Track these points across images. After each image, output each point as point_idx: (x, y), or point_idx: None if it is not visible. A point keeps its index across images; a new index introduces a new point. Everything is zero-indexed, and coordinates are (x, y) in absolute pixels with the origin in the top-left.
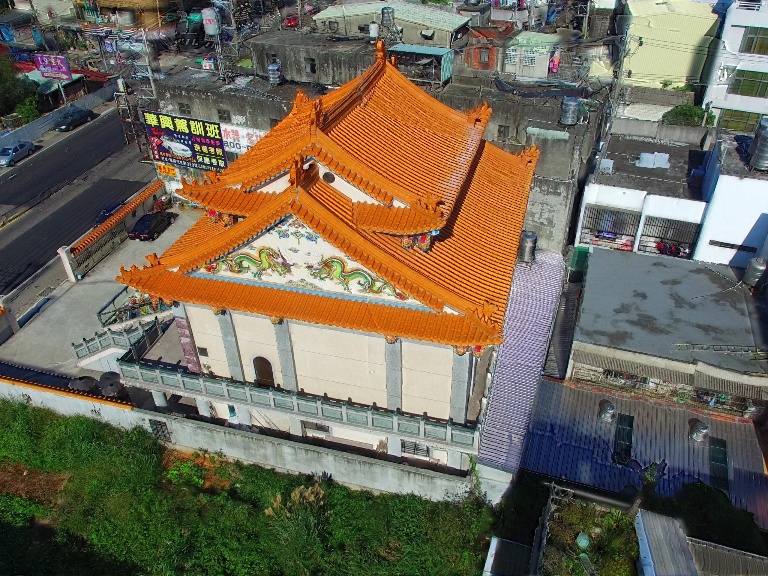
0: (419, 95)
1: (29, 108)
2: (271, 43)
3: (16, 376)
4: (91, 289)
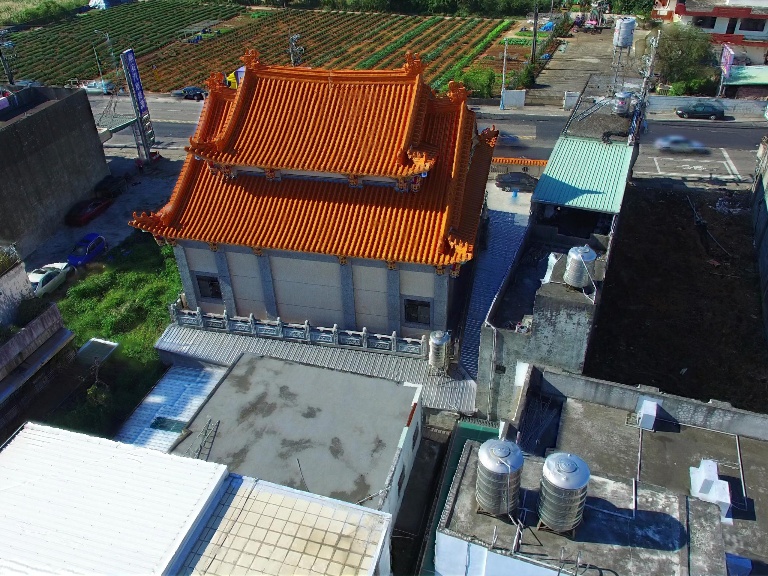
0: None
1: (679, 86)
2: None
3: None
4: None
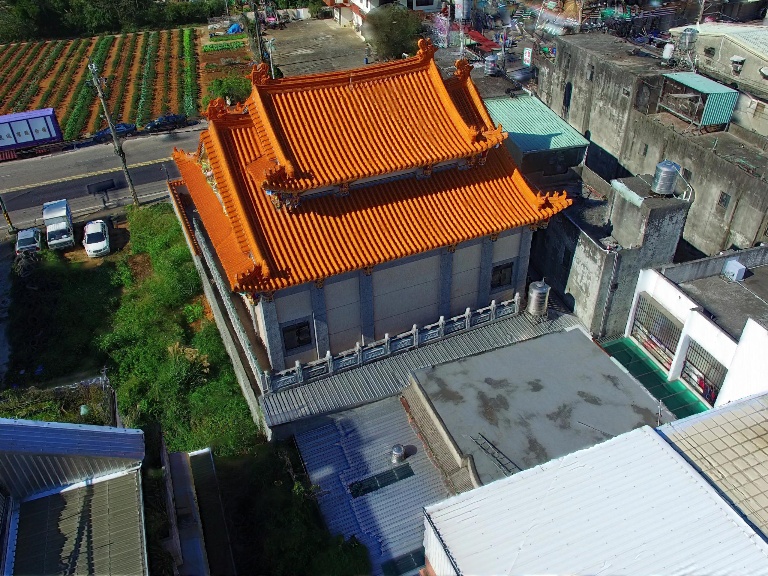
0: (445, 98)
1: None
2: (572, 43)
3: None
4: None
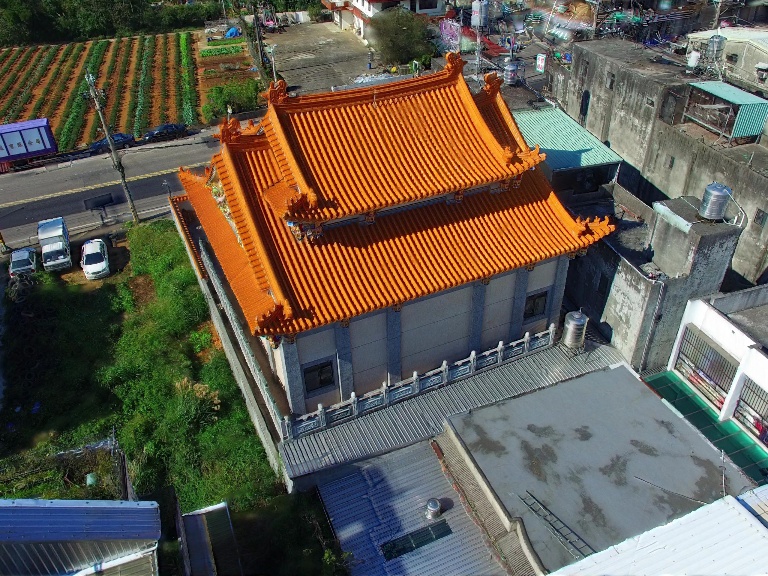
0: (475, 116)
1: None
2: (589, 49)
3: None
4: None
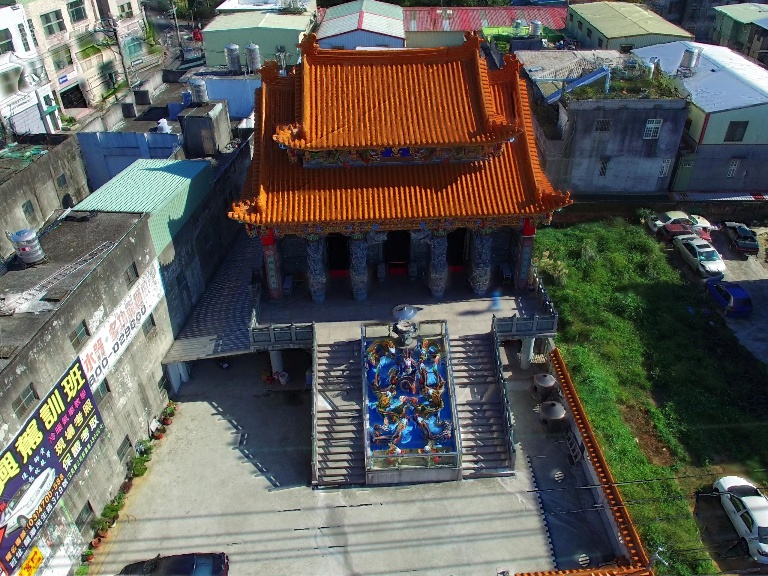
0: None
1: None
2: None
3: (564, 533)
4: (373, 570)
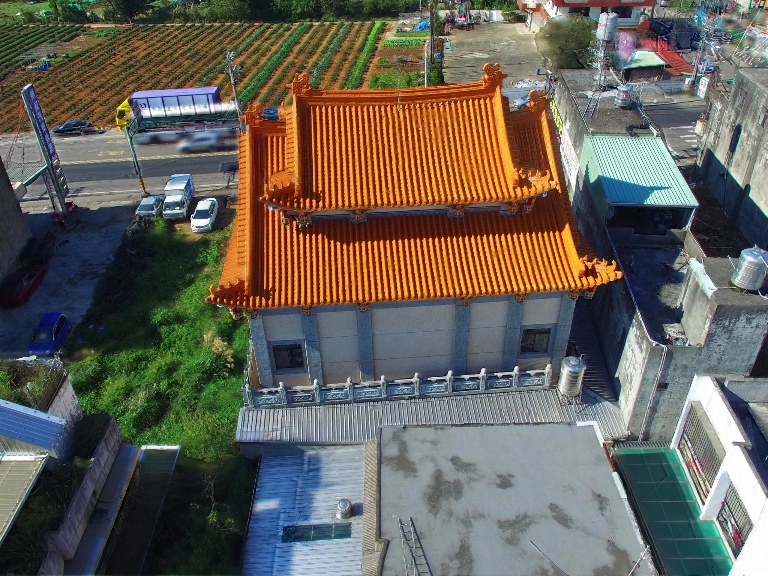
0: (501, 132)
1: None
2: (751, 78)
3: None
4: None
